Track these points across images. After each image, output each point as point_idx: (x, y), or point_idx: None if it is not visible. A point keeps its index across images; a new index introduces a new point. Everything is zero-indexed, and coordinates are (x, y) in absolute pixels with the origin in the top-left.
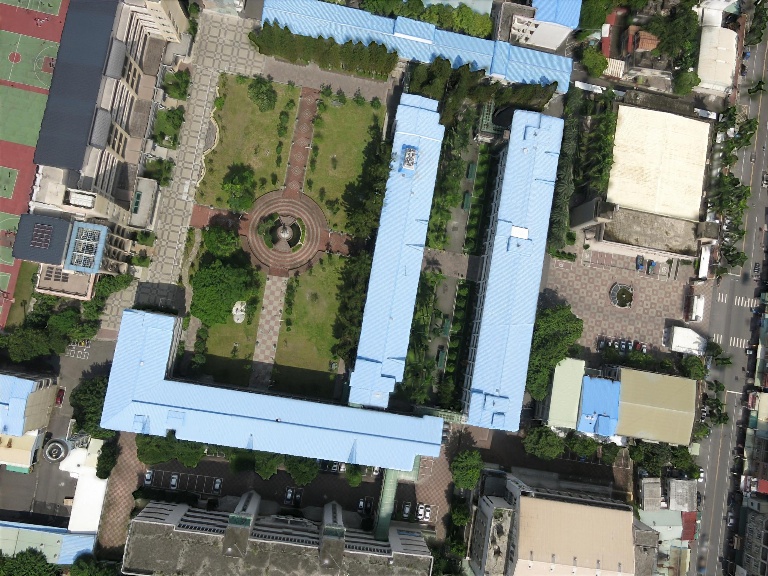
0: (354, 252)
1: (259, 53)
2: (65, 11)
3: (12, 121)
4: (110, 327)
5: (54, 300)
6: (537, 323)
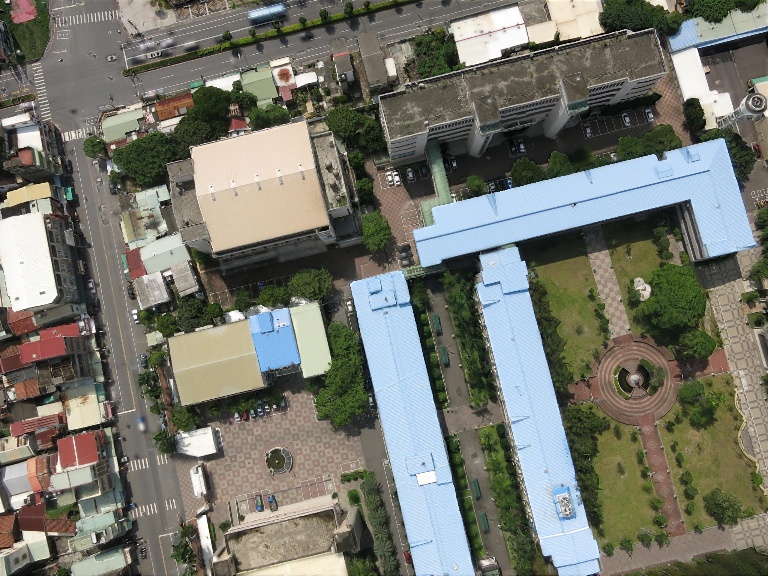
0: None
1: None
2: None
3: None
4: None
5: None
6: None
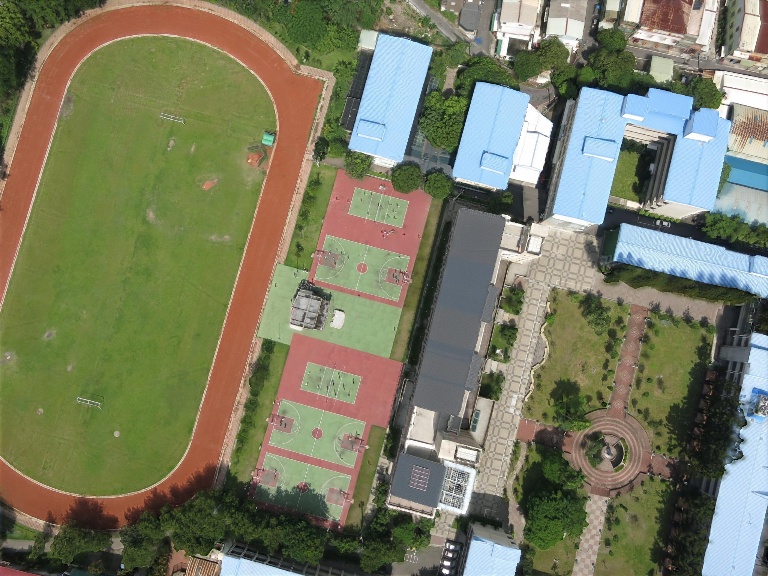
0: (676, 476)
1: (590, 268)
2: (409, 223)
3: (358, 329)
4: (438, 533)
5: (397, 511)
6: None
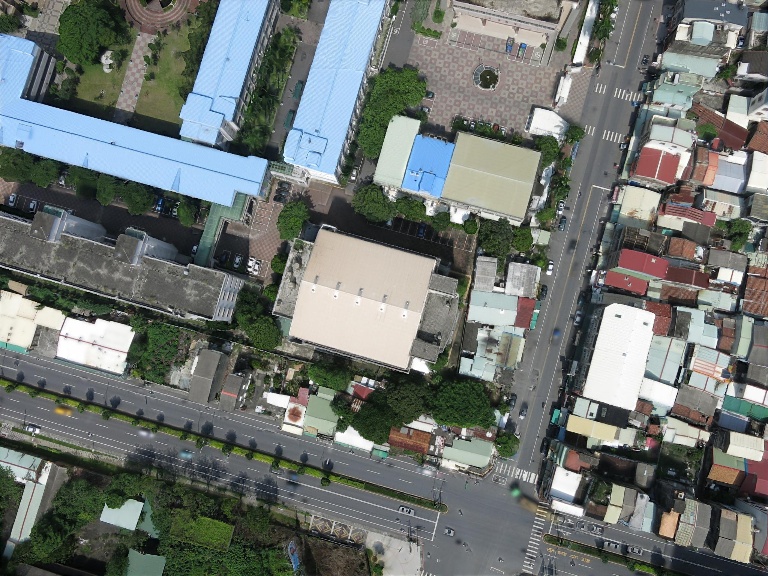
0: None
1: None
2: None
3: None
4: None
5: None
6: (375, 79)
